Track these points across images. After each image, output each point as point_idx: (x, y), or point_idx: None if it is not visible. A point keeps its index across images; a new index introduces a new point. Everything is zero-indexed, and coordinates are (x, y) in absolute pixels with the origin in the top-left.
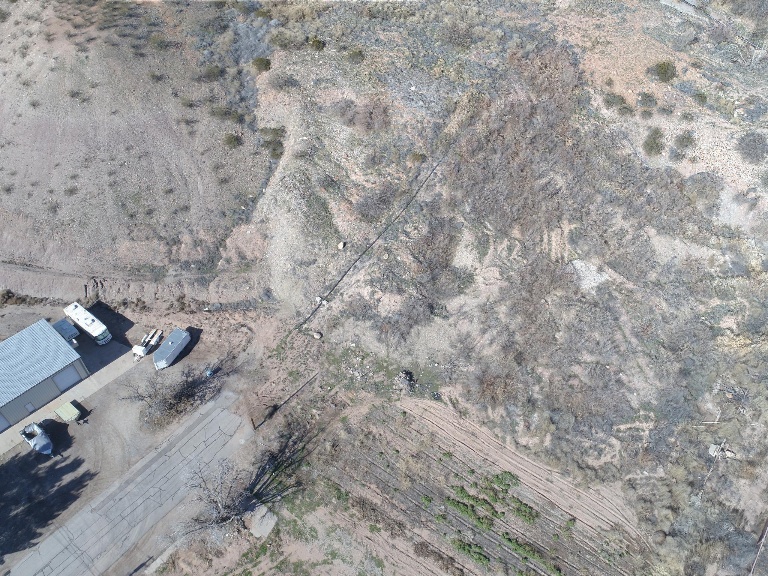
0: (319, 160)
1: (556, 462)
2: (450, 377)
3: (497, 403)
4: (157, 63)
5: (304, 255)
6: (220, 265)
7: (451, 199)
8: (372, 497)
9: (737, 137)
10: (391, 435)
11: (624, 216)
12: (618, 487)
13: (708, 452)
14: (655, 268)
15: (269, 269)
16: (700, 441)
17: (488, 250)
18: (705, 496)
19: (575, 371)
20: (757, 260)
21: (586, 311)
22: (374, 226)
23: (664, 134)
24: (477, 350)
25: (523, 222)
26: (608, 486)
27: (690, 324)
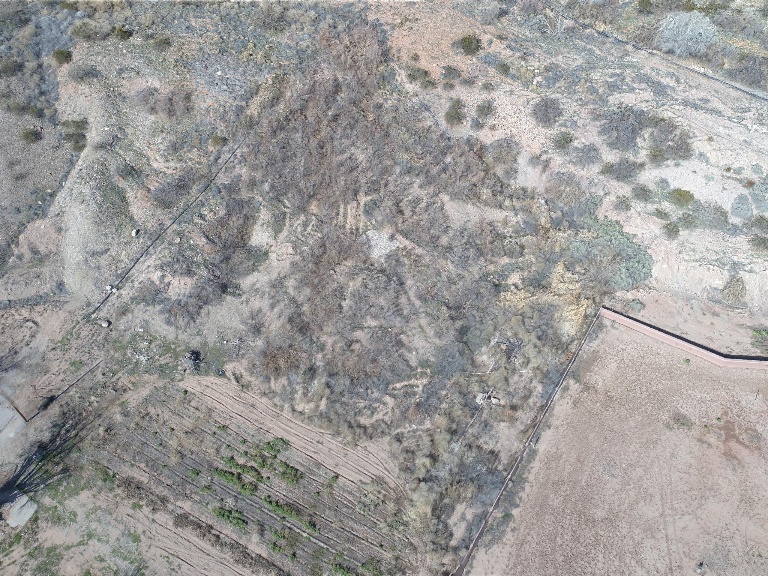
0: (120, 150)
1: (327, 424)
2: (237, 353)
3: (280, 374)
4: None
5: (96, 245)
6: (11, 262)
7: (251, 180)
8: (139, 476)
9: (533, 103)
10: (169, 414)
11: (421, 185)
12: (385, 442)
13: (475, 401)
14: (447, 233)
15: (63, 262)
16: (469, 391)
17: (284, 227)
18: (465, 442)
19: (357, 336)
20: (545, 218)
21: (372, 278)
22: (170, 211)
23: (465, 104)
24: (267, 325)
25: (320, 197)
26: (376, 442)
27: (475, 283)
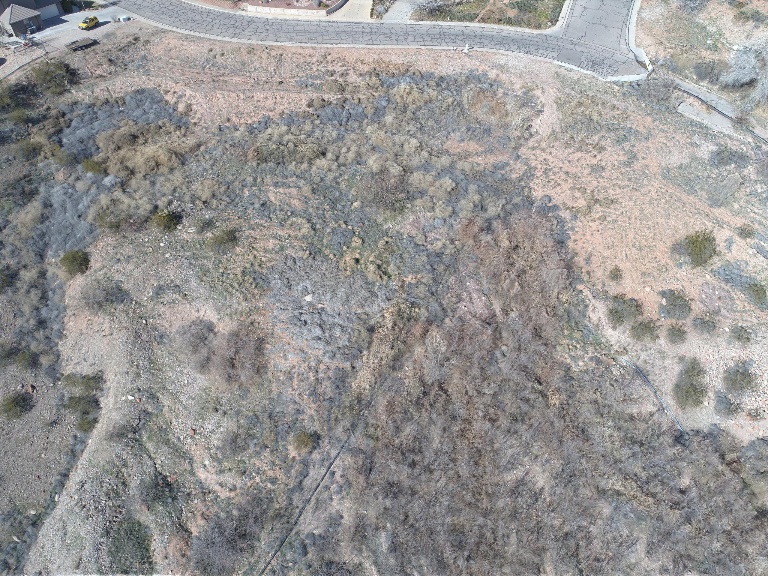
0: (148, 441)
1: None
2: None
3: None
4: None
5: None
6: None
7: (357, 525)
8: None
9: None
10: None
11: (649, 547)
12: None
13: None
14: None
15: None
16: None
17: None
18: None
19: None
20: None
21: None
22: None
23: (705, 368)
24: None
25: (477, 575)
26: None
27: None
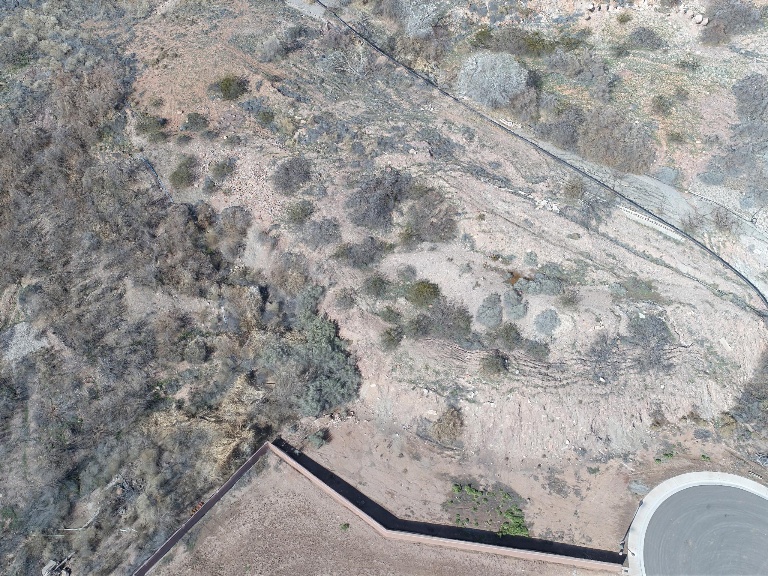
0: None
1: None
2: None
3: None
4: None
5: None
6: None
7: None
8: None
9: (279, 164)
10: None
11: (108, 265)
12: None
13: (41, 572)
14: (119, 328)
15: None
16: (42, 556)
17: None
18: None
19: None
20: (251, 312)
21: None
22: None
23: (201, 162)
24: None
25: None
26: None
27: (123, 399)
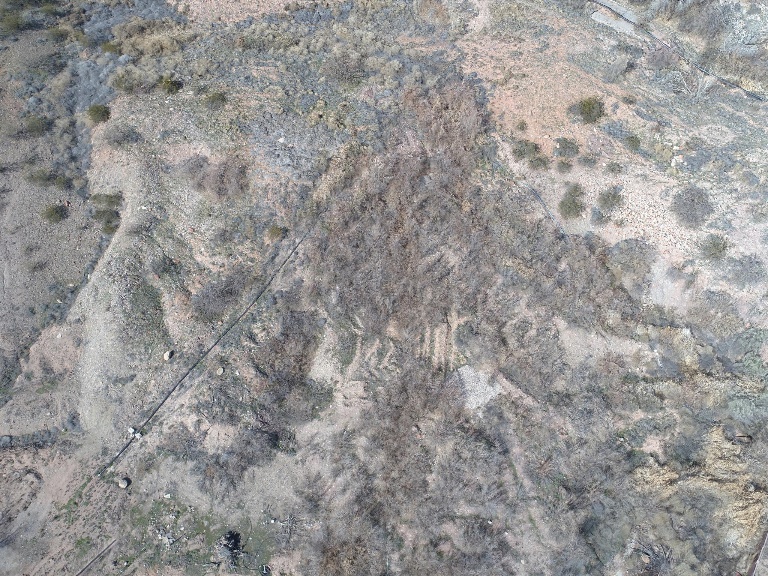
0: (158, 236)
1: None
2: (288, 540)
3: None
4: None
5: (120, 369)
6: (17, 382)
7: (314, 286)
8: None
9: (673, 194)
10: None
11: (529, 303)
12: None
13: None
14: (564, 373)
15: (79, 386)
16: None
17: (353, 356)
18: None
19: (447, 531)
20: (692, 357)
21: (468, 442)
22: (213, 327)
23: (585, 191)
24: (327, 498)
25: (401, 316)
26: None
27: (602, 453)
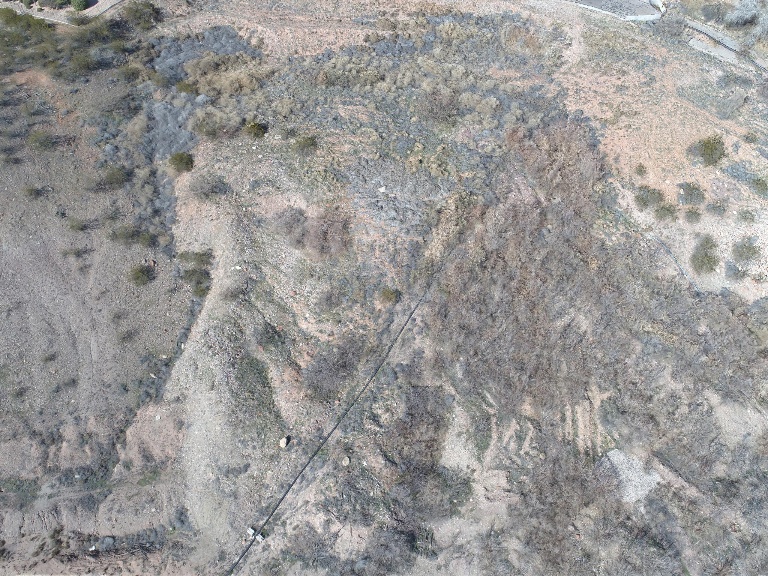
0: (257, 300)
1: None
2: None
3: None
4: (38, 170)
5: (232, 458)
6: (116, 473)
7: (436, 358)
8: None
9: None
10: None
11: (674, 373)
12: None
13: None
14: (723, 456)
15: (184, 476)
16: None
17: (490, 440)
18: None
19: None
20: None
21: (634, 544)
22: (330, 407)
23: (717, 243)
24: None
25: (536, 392)
26: None
27: None
